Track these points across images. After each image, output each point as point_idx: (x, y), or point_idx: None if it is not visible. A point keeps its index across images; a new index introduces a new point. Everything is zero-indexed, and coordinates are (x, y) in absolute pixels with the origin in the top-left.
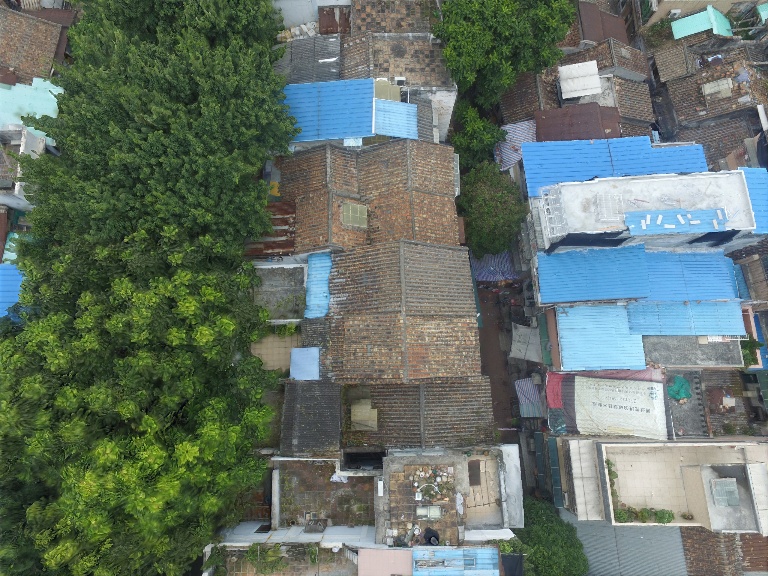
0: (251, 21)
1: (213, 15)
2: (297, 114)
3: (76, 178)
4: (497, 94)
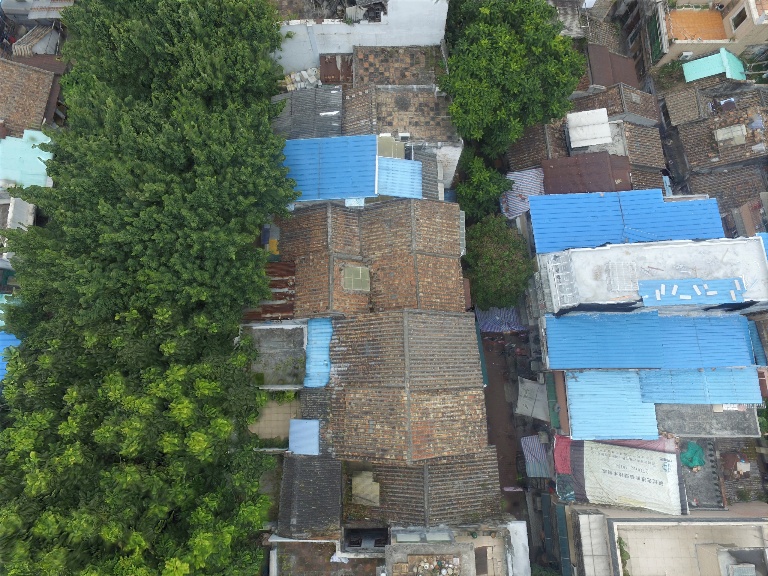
0: (249, 80)
1: (210, 77)
2: (297, 172)
3: (65, 255)
4: None
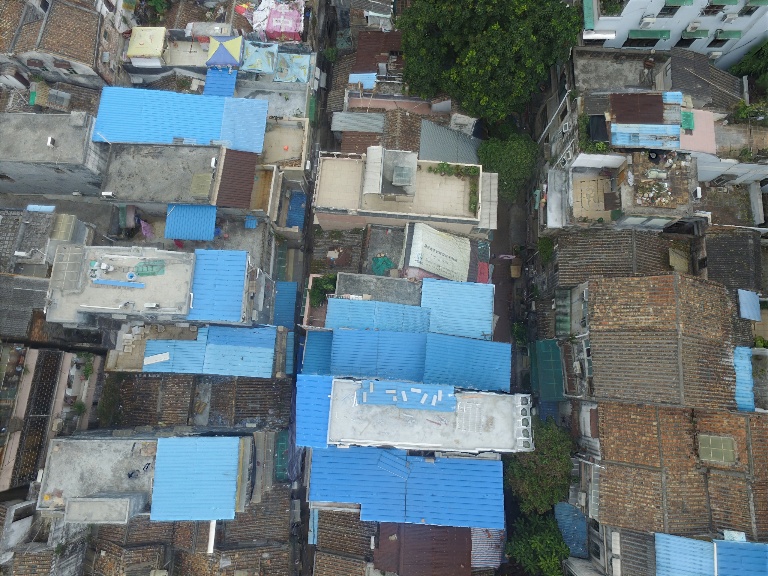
0: None
1: None
2: None
3: None
4: None
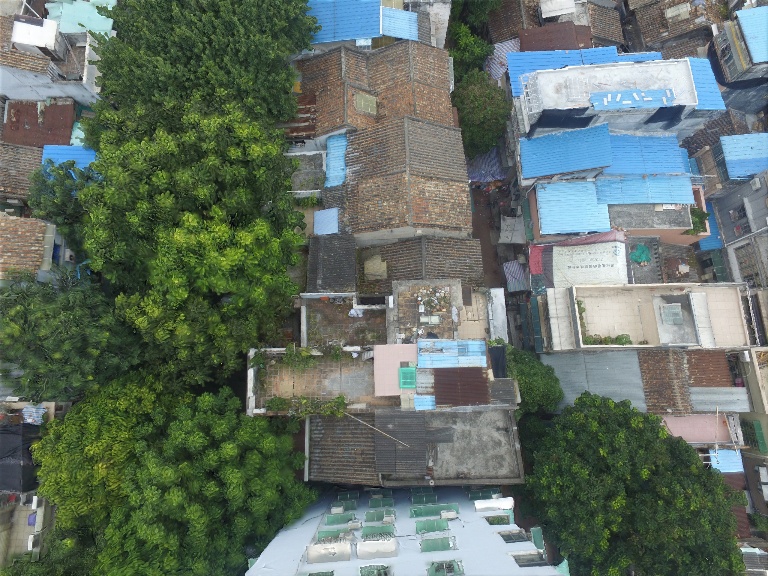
0: None
1: None
2: None
3: (143, 53)
4: (486, 13)
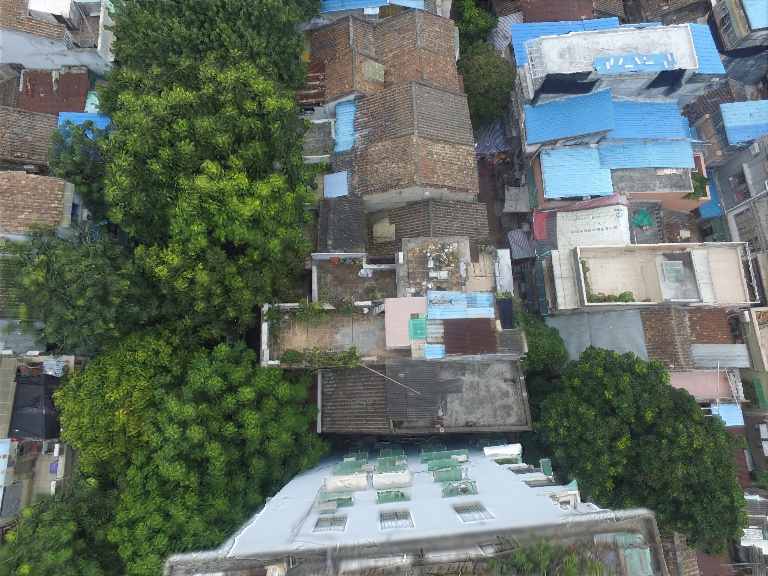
0: None
1: None
2: None
3: (158, 16)
4: None
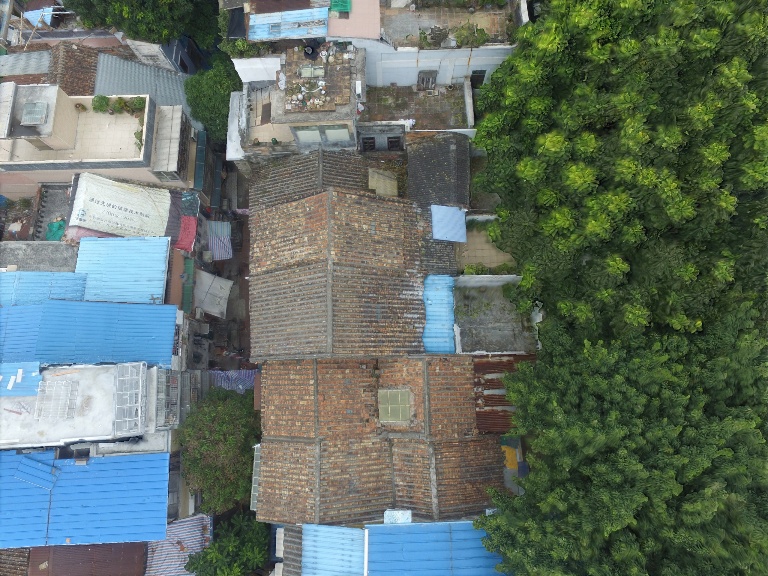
0: None
1: None
2: (487, 573)
3: None
4: None
